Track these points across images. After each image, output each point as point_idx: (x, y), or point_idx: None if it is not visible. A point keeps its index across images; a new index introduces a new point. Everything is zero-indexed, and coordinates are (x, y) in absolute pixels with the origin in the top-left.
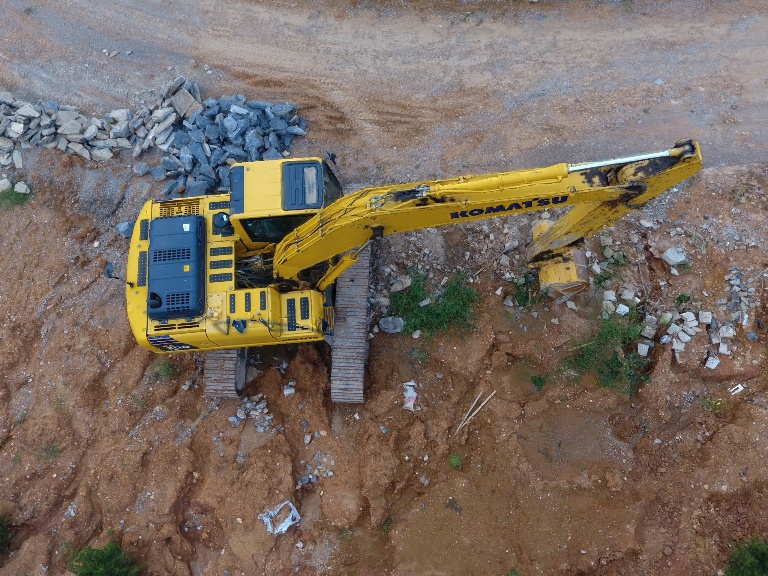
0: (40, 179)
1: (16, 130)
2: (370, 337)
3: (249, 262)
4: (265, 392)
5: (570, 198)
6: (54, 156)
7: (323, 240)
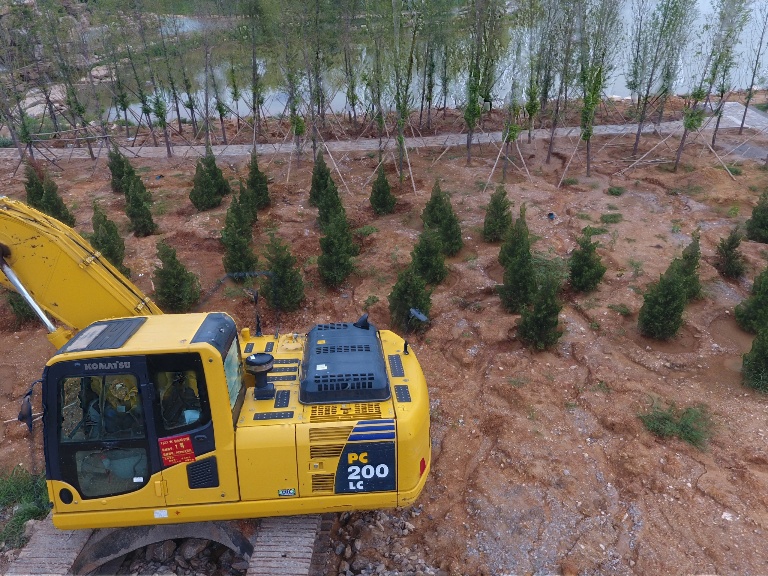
0: None
1: None
2: None
3: None
4: None
5: None
6: None
7: None
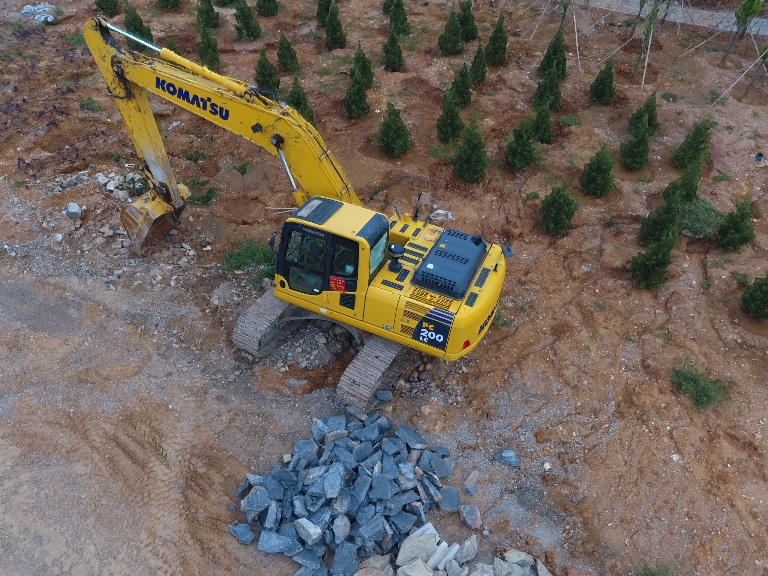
0: None
1: None
2: None
3: None
4: None
5: None
6: None
7: None
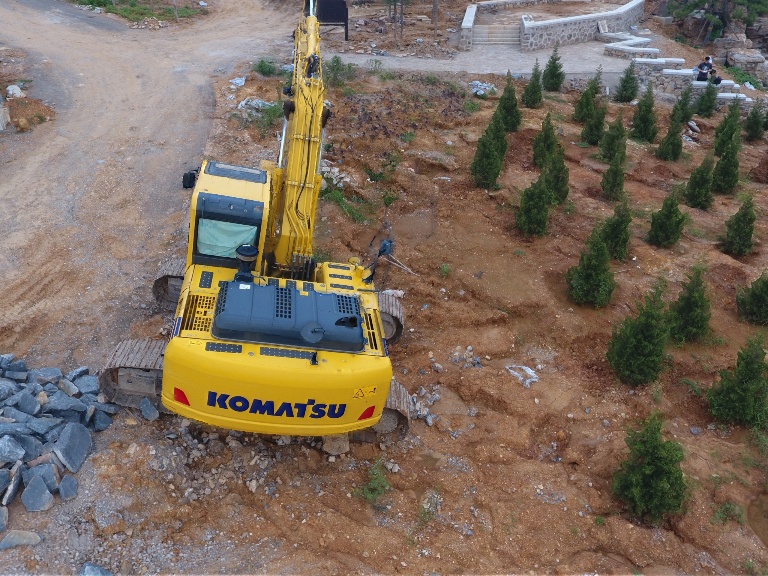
0: None
1: None
2: None
3: None
4: None
5: None
6: None
7: None
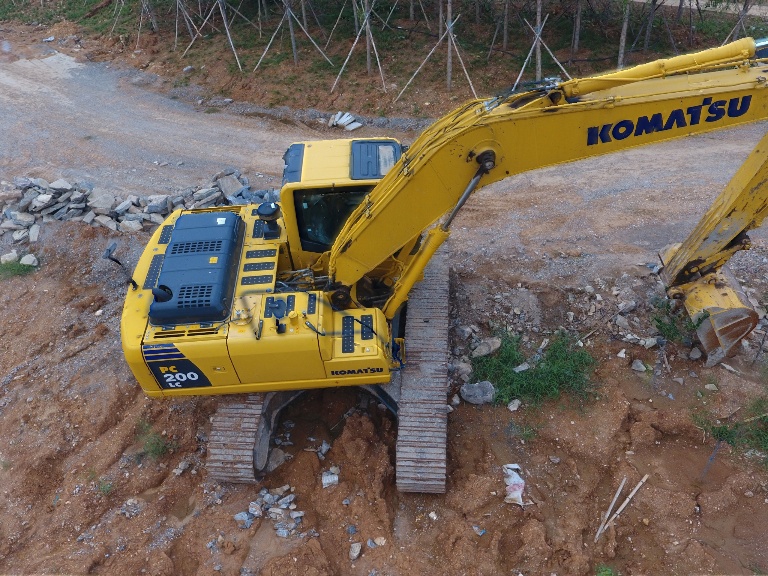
0: (53, 251)
1: (42, 199)
2: (448, 410)
3: (295, 274)
4: (293, 483)
5: (753, 103)
6: (76, 228)
7: (407, 189)
